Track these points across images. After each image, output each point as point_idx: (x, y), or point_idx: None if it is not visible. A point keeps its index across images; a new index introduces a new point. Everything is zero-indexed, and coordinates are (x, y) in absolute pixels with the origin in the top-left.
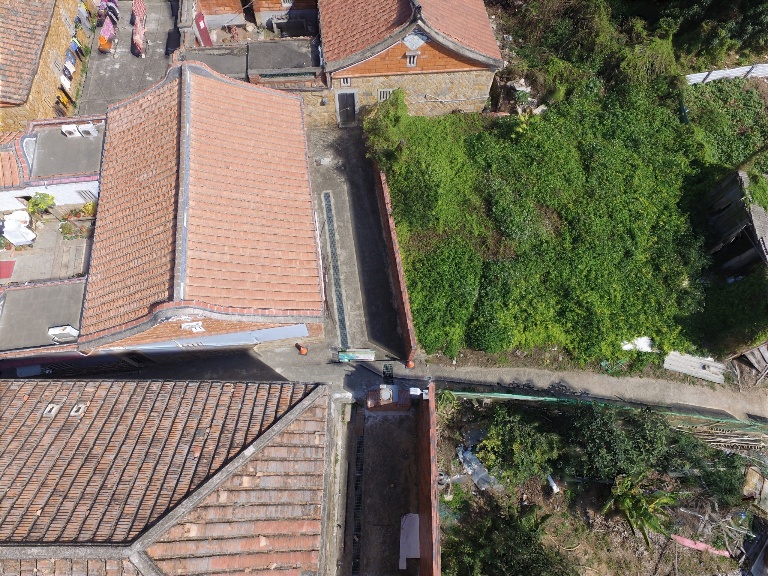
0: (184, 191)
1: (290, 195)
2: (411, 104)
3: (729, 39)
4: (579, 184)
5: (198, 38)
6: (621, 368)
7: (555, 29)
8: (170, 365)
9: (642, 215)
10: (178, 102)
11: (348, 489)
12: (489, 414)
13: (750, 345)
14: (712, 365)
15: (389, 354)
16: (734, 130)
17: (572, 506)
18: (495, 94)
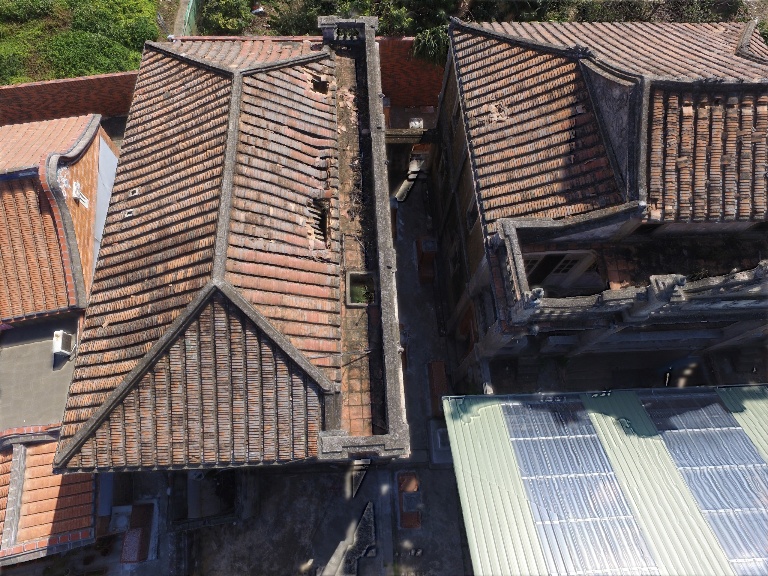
0: None
1: None
2: None
3: None
4: None
5: None
6: None
7: None
8: None
9: None
10: None
11: None
12: None
13: None
14: None
15: None
16: None
17: None
18: None
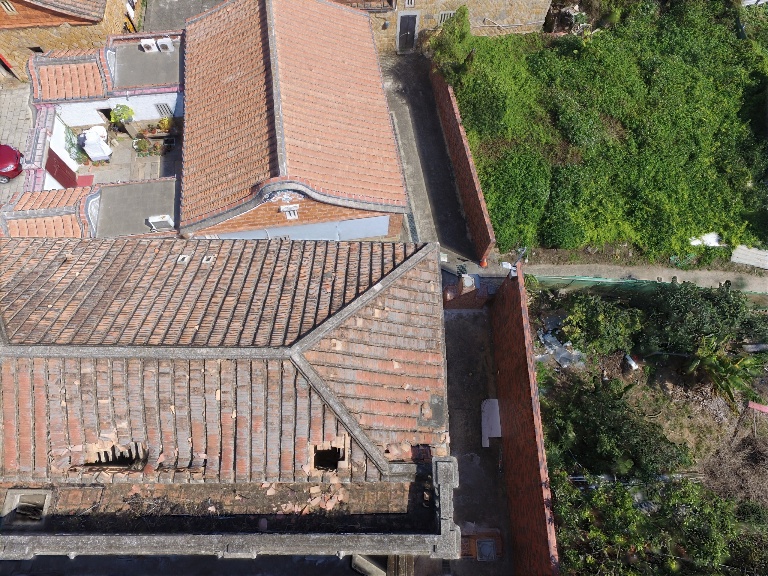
0: (277, 84)
1: (368, 100)
2: None
3: None
4: (641, 95)
5: None
6: (689, 262)
7: None
8: None
9: (705, 122)
10: (260, 9)
11: None
12: None
13: None
14: None
15: (461, 257)
16: None
17: (651, 380)
18: (548, 22)
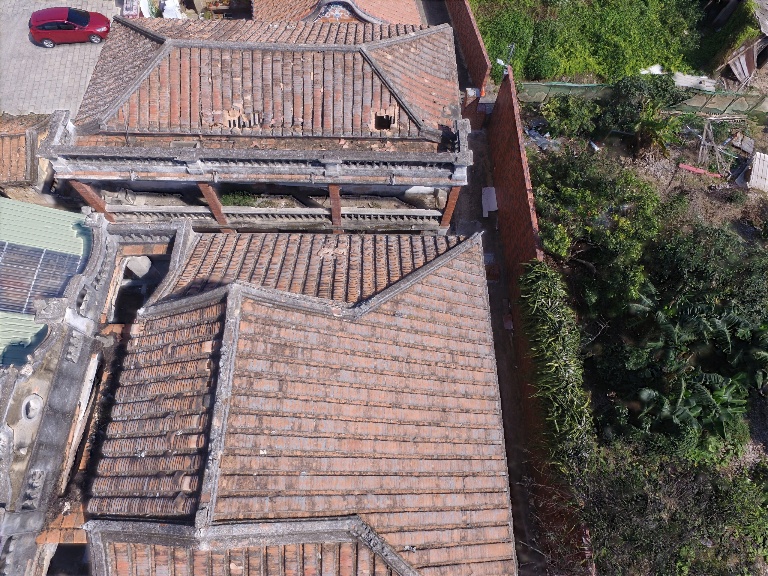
0: None
1: None
2: None
3: None
4: None
5: None
6: None
7: None
8: None
9: None
10: None
11: None
12: None
13: (733, 46)
14: (706, 81)
15: (464, 93)
16: None
17: (609, 155)
18: None
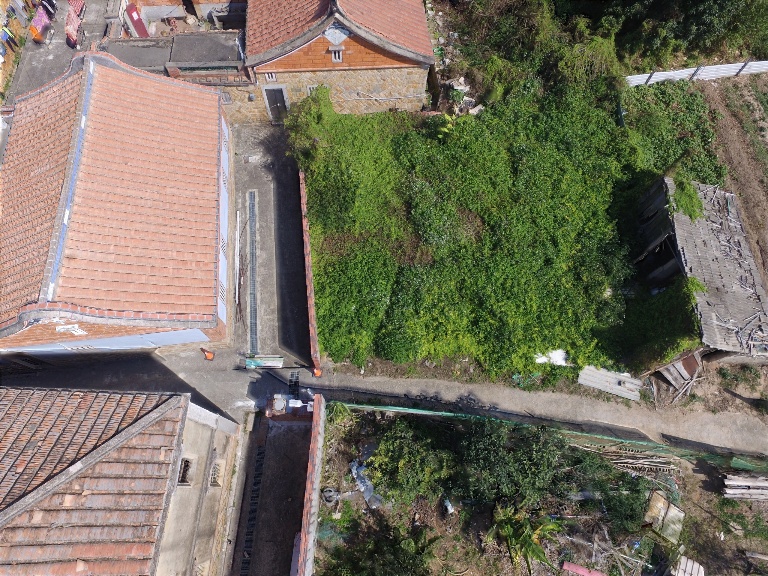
0: (68, 187)
1: (194, 193)
2: (344, 101)
3: (674, 40)
4: (505, 188)
5: (132, 30)
6: (534, 382)
7: (499, 27)
8: (69, 368)
9: (567, 221)
10: None
11: (243, 502)
12: (391, 427)
13: (660, 361)
14: (628, 381)
15: (299, 361)
16: (673, 134)
17: (465, 528)
18: (435, 93)
